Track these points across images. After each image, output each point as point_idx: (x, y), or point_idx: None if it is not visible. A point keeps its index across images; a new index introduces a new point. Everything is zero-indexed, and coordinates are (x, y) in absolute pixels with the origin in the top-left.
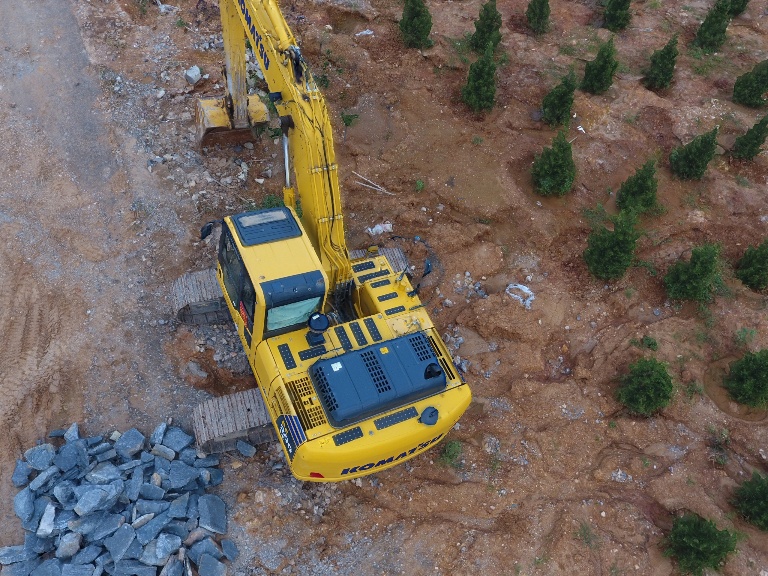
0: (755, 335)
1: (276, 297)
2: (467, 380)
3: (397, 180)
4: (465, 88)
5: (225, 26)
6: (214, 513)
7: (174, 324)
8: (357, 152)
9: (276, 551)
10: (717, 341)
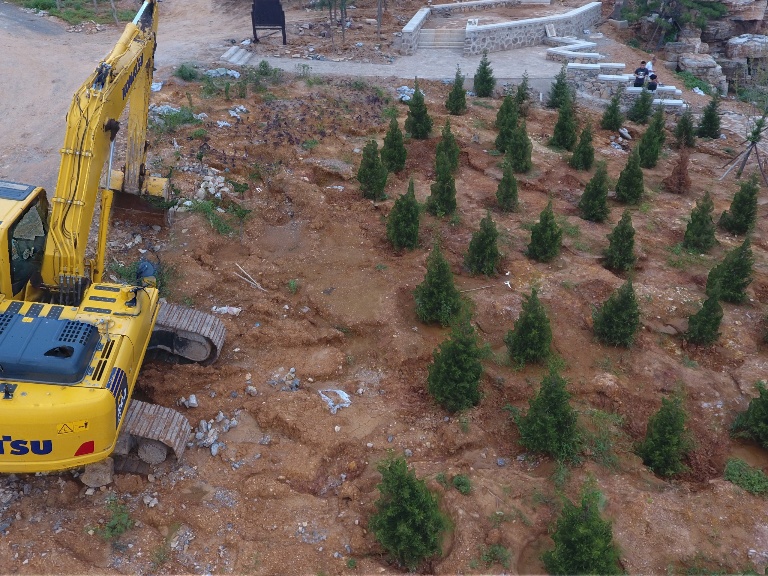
0: (623, 516)
1: None
2: (211, 465)
3: (279, 282)
4: (388, 223)
5: None
6: None
7: None
8: (254, 253)
9: None
10: None
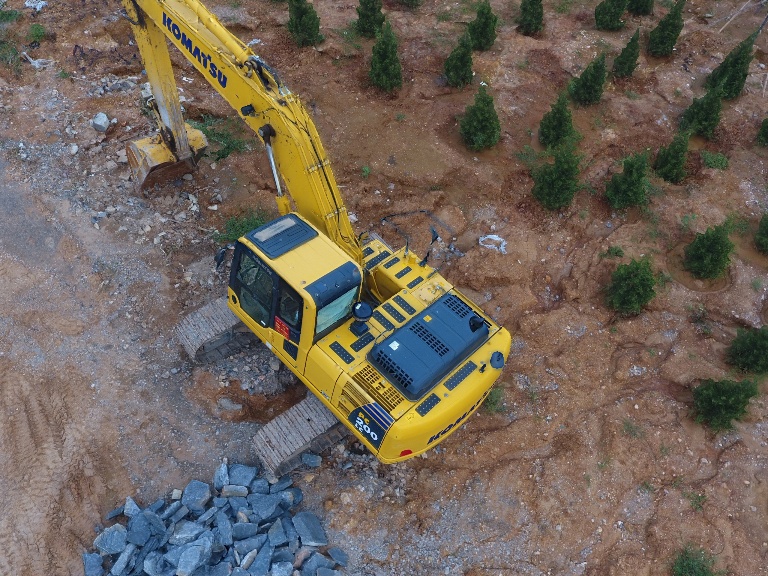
0: (693, 219)
1: (322, 297)
2: None
3: (342, 172)
4: (373, 71)
5: (148, 59)
6: (311, 528)
7: (187, 369)
8: None
9: (381, 541)
10: (666, 234)
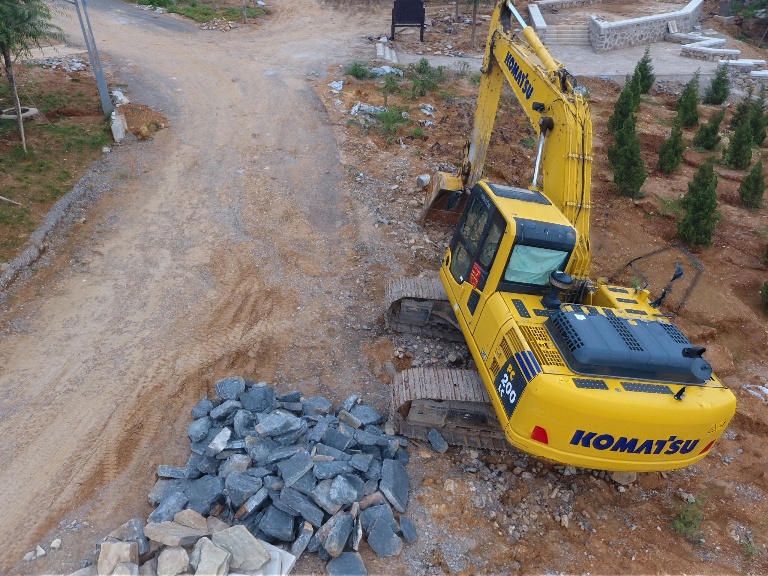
0: None
1: (526, 232)
2: None
3: None
4: (682, 221)
5: (481, 102)
6: (398, 481)
7: (376, 332)
8: None
9: (462, 549)
10: None
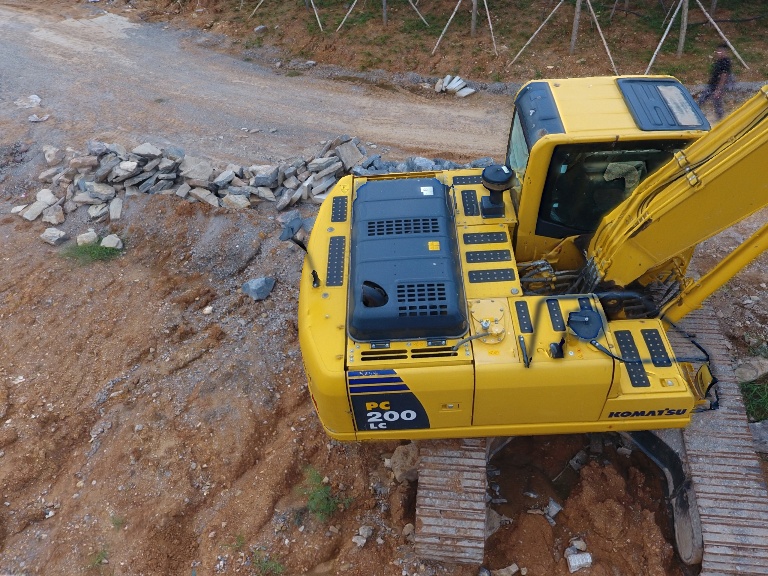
0: None
1: None
2: None
3: None
4: None
5: None
6: None
7: None
8: None
9: None
10: None
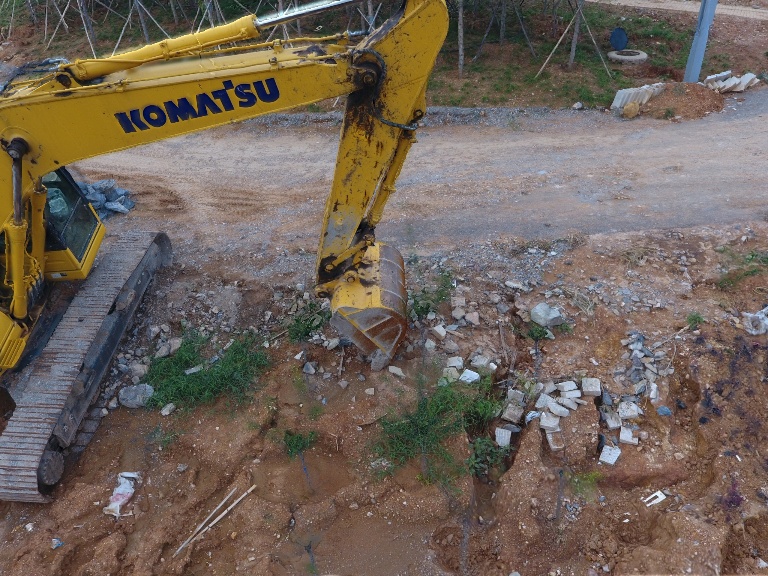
0: None
1: None
2: None
3: (207, 574)
4: None
5: None
6: None
7: None
8: (298, 511)
9: None
10: None
